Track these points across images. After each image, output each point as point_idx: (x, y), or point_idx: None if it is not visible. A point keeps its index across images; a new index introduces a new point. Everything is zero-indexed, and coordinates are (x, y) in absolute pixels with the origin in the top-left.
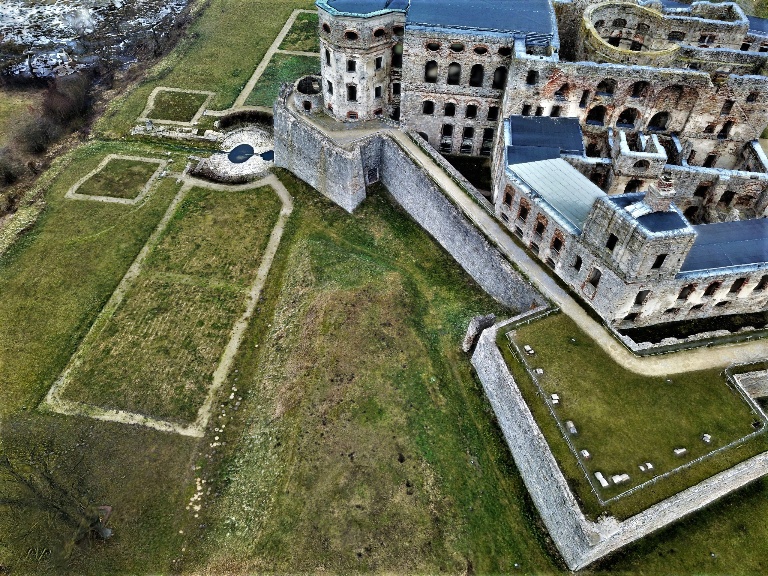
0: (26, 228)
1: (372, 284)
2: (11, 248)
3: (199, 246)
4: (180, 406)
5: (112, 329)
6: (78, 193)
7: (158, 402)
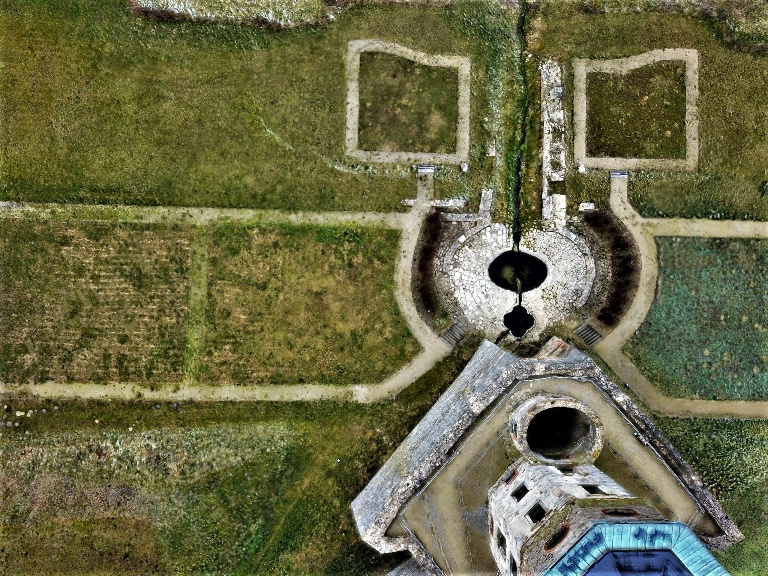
0: (269, 24)
1: (171, 575)
2: (228, 26)
3: (263, 288)
4: (0, 358)
5: (99, 232)
6: (361, 58)
7: (3, 331)
